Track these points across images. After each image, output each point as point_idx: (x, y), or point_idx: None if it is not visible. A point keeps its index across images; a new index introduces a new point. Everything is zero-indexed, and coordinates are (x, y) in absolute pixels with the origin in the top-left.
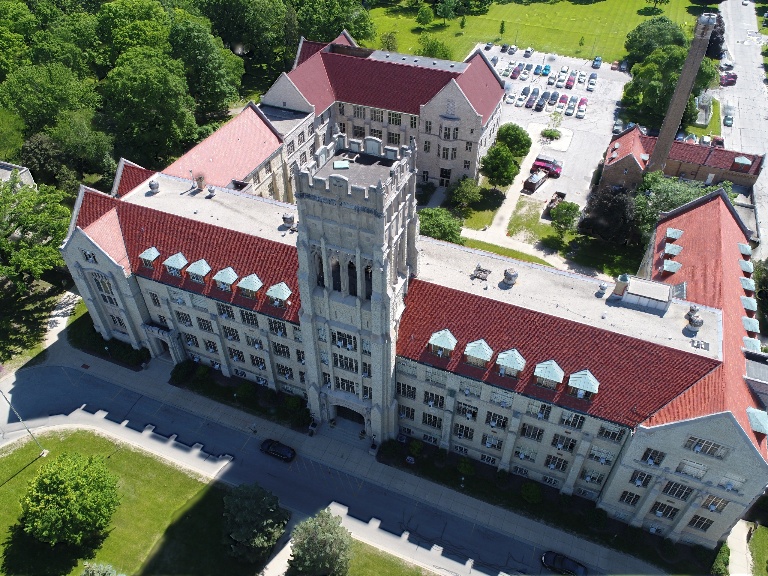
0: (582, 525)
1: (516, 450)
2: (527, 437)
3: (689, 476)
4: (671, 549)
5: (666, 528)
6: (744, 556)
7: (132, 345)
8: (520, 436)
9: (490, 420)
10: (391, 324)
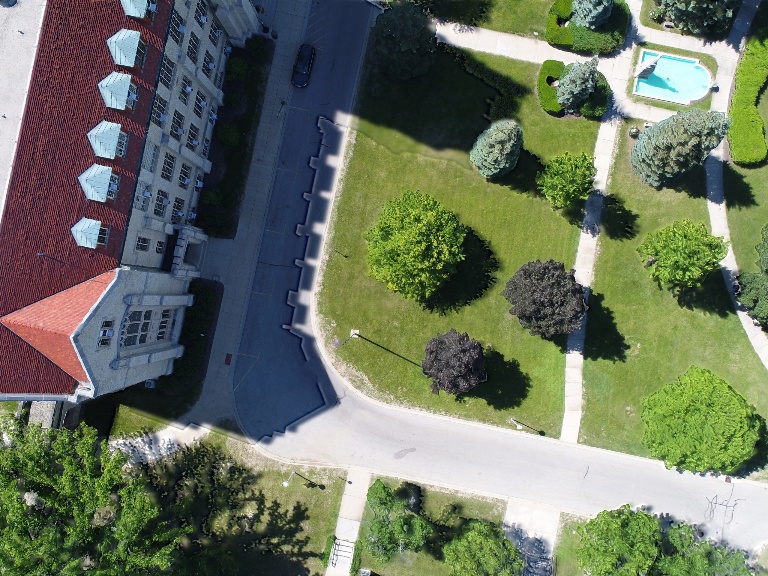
0: None
1: None
2: None
3: None
4: None
5: None
6: None
7: (189, 306)
8: None
9: None
10: None
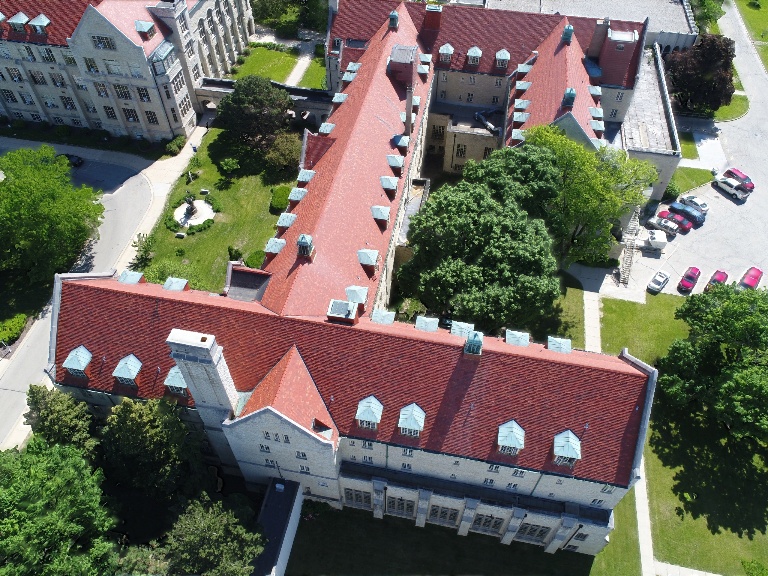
0: (93, 142)
1: (44, 101)
2: (39, 84)
3: (117, 75)
4: (142, 142)
5: (141, 131)
6: (196, 143)
7: None
8: (34, 84)
9: (13, 76)
10: None
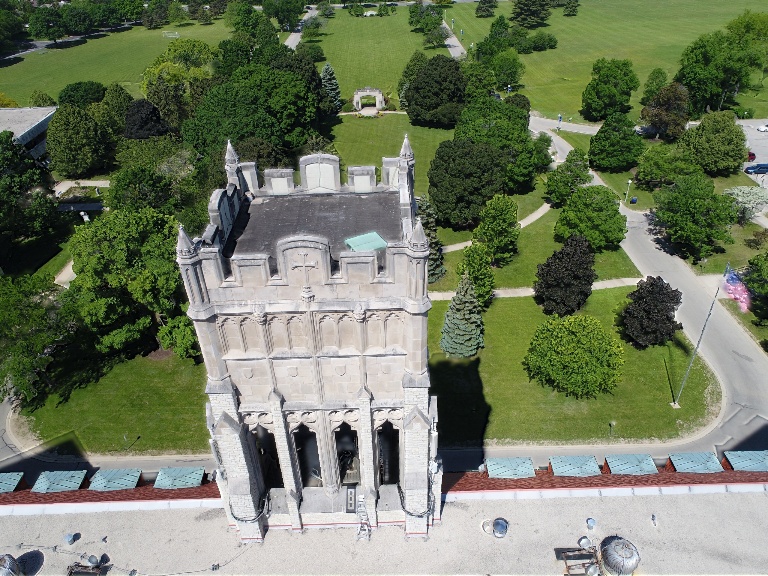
0: None
1: None
2: None
3: None
4: None
5: None
6: None
7: None
8: None
9: None
10: None
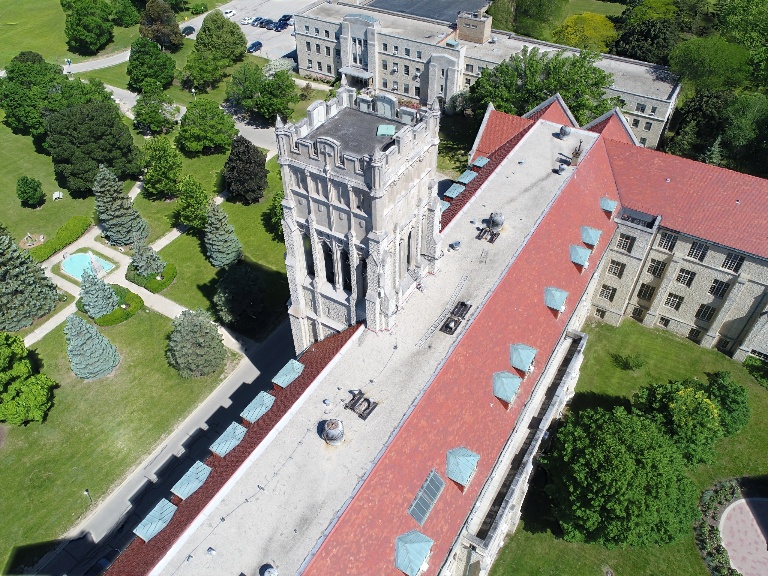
0: None
1: None
2: None
3: None
4: None
5: None
6: None
7: None
8: None
9: None
10: (296, 299)
